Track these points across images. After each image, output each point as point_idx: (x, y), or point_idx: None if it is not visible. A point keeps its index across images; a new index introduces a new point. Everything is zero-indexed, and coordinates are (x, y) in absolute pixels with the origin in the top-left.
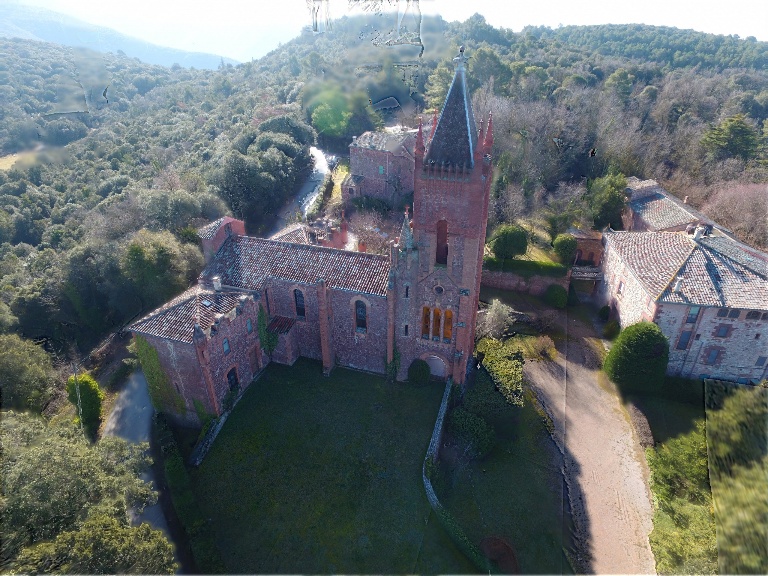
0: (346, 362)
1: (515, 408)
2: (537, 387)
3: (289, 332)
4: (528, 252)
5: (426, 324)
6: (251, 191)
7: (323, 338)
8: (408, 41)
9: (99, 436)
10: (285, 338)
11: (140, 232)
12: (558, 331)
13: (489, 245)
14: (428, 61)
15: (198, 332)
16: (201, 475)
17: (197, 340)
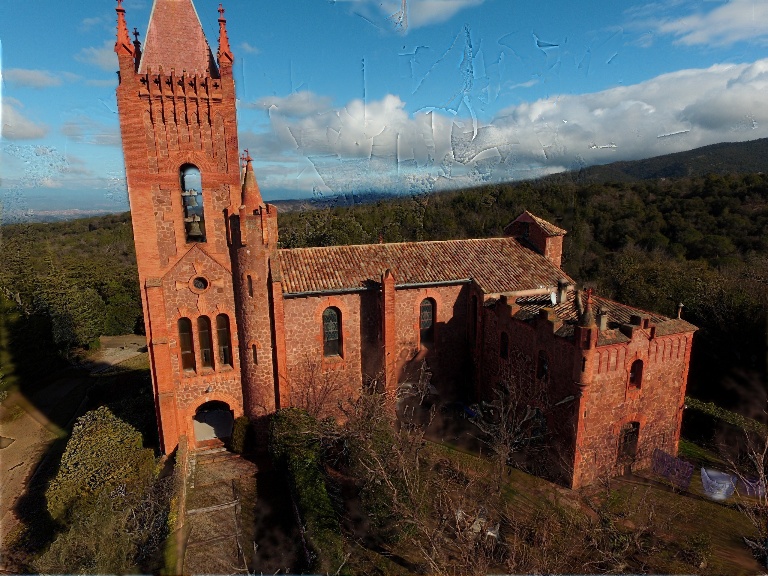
0: None
1: None
2: None
3: None
4: None
5: None
6: None
7: None
8: None
9: None
10: None
11: None
12: None
13: None
14: None
15: None
16: None
17: None
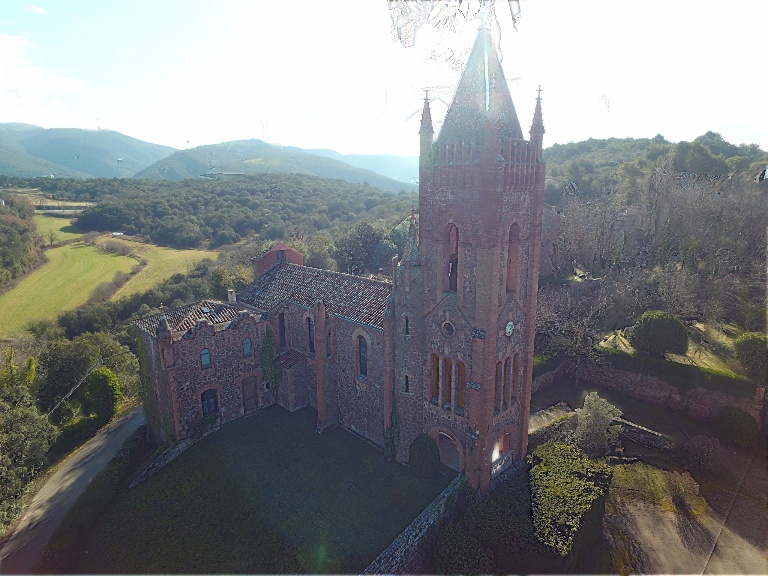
0: (348, 422)
1: (548, 552)
2: (643, 550)
3: (293, 368)
4: (698, 359)
5: (437, 382)
6: (372, 257)
7: (318, 379)
8: None
9: (94, 434)
10: (288, 374)
11: (236, 266)
12: (723, 477)
13: (624, 334)
14: (508, 74)
15: (161, 325)
16: (124, 499)
17: (158, 334)
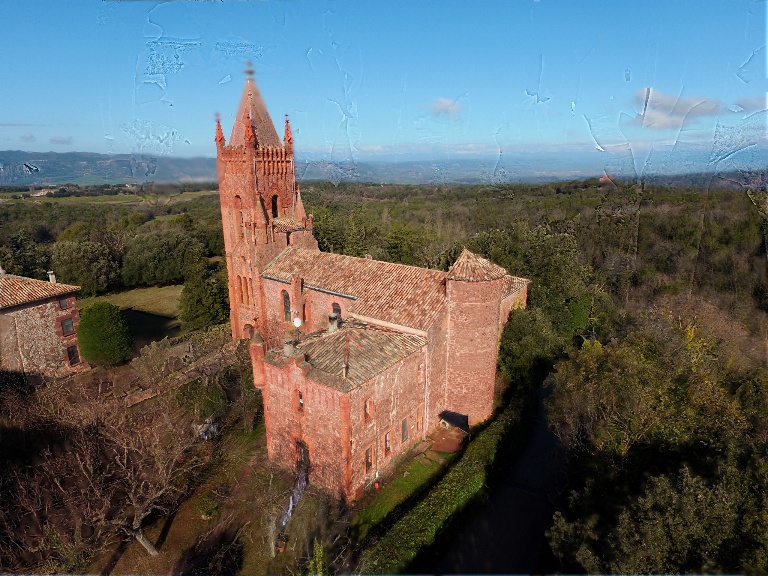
0: None
1: None
2: None
3: None
4: None
5: None
6: None
7: None
8: None
9: None
10: None
11: None
12: None
13: None
14: None
15: None
16: None
17: None
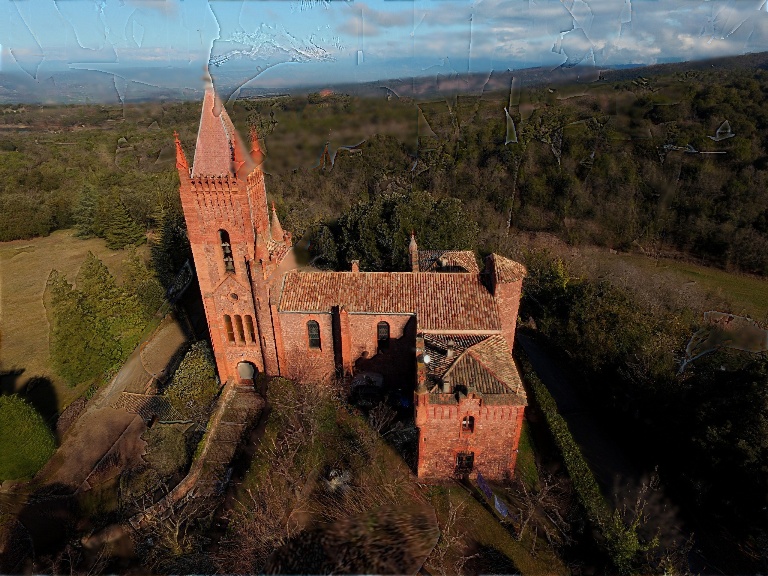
0: None
1: None
2: None
3: None
4: None
5: None
6: None
7: None
8: (260, 49)
9: None
10: None
11: None
12: None
13: None
14: None
15: None
16: None
17: None
